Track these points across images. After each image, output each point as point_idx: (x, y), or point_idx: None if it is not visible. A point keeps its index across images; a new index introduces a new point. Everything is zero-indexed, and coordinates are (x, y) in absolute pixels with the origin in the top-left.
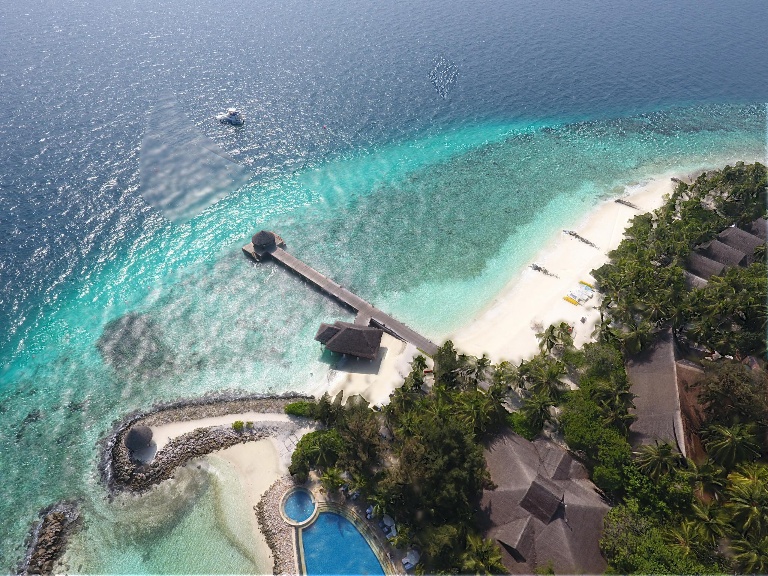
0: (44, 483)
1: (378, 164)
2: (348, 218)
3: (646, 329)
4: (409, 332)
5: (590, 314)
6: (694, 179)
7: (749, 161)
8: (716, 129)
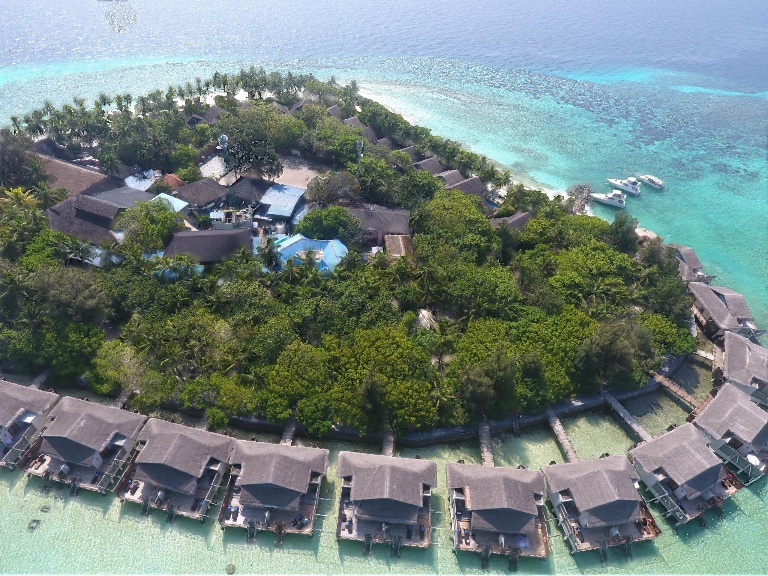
0: None
1: (26, 73)
2: None
3: (18, 132)
4: None
5: None
6: None
7: None
8: (344, 68)
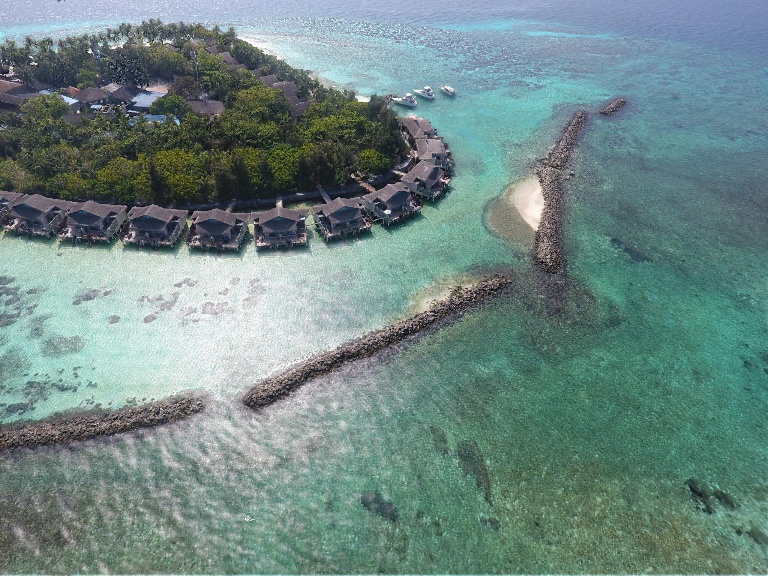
0: None
1: None
2: None
3: None
4: None
5: None
6: None
7: None
8: (245, 25)
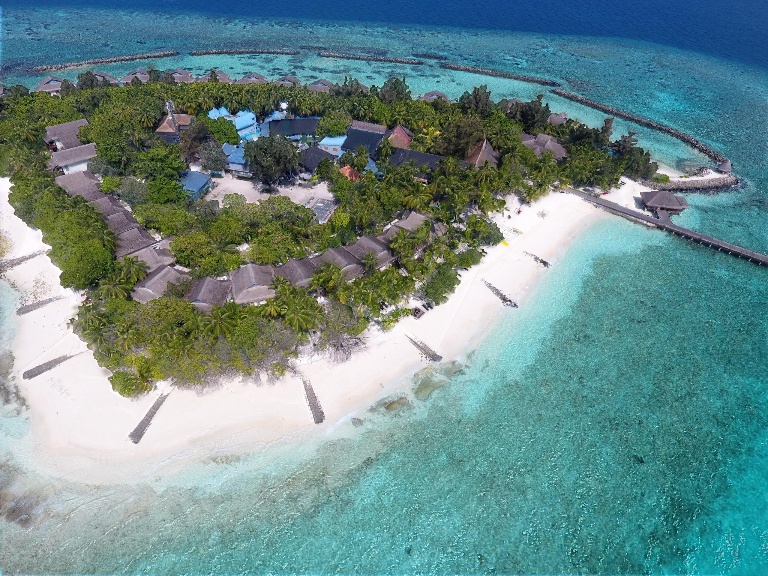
0: (745, 171)
1: None
2: (767, 321)
3: None
4: (629, 212)
5: (503, 222)
6: (280, 422)
7: (91, 508)
8: None
